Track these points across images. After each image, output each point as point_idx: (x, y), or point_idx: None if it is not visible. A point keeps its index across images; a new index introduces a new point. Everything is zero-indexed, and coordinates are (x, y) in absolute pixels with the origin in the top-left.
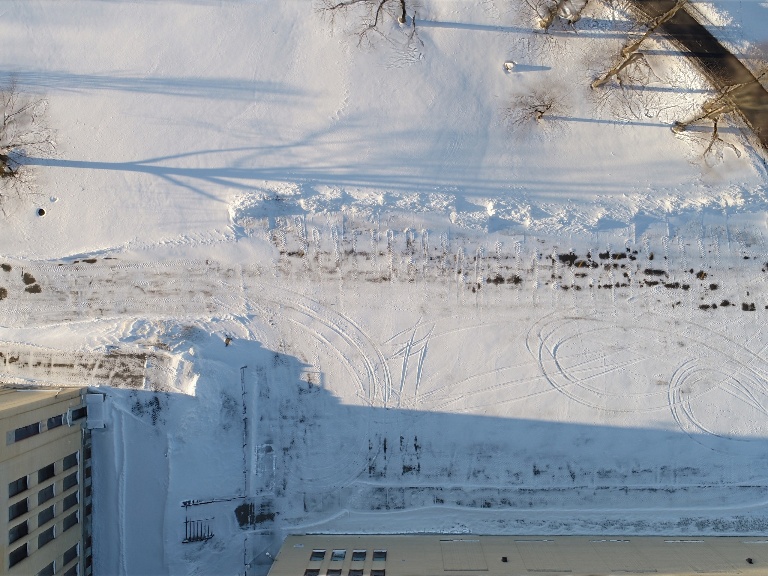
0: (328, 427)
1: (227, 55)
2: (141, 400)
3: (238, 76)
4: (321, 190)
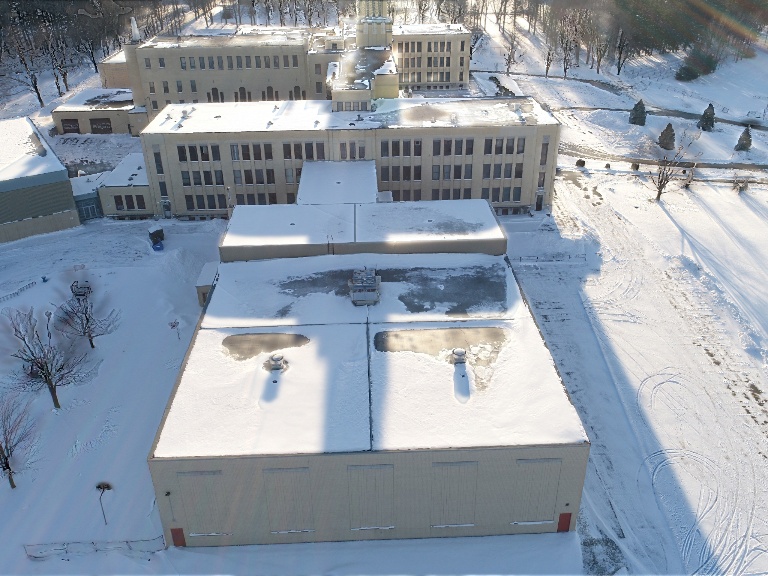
0: (561, 287)
1: None
2: (551, 226)
3: (765, 263)
4: (718, 284)
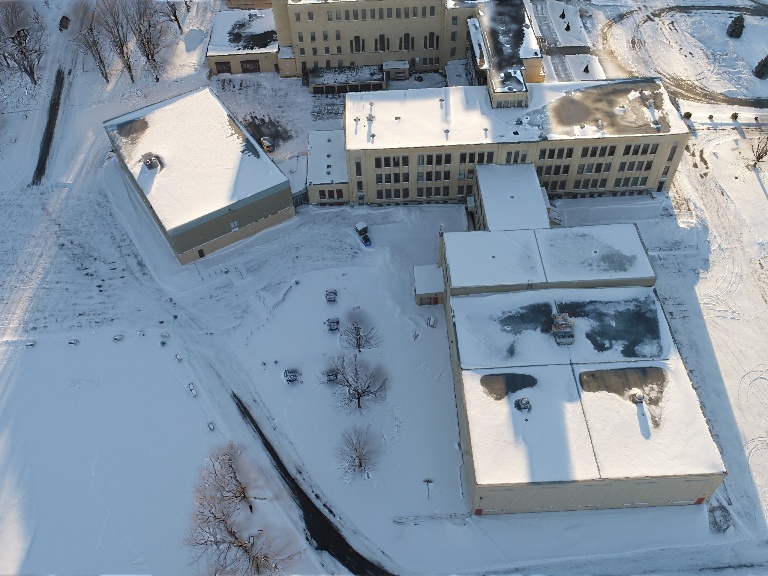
0: (681, 281)
1: None
2: (670, 210)
3: None
4: None
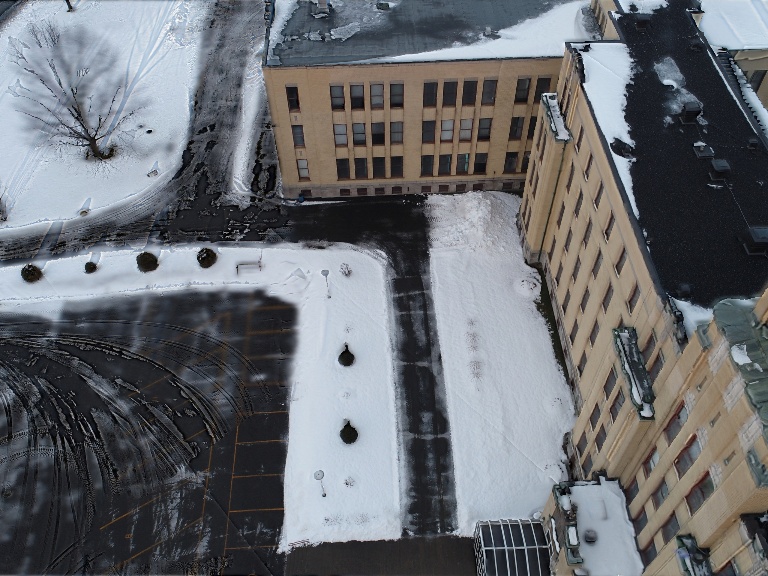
0: None
1: (61, 66)
2: None
3: (79, 60)
4: None
